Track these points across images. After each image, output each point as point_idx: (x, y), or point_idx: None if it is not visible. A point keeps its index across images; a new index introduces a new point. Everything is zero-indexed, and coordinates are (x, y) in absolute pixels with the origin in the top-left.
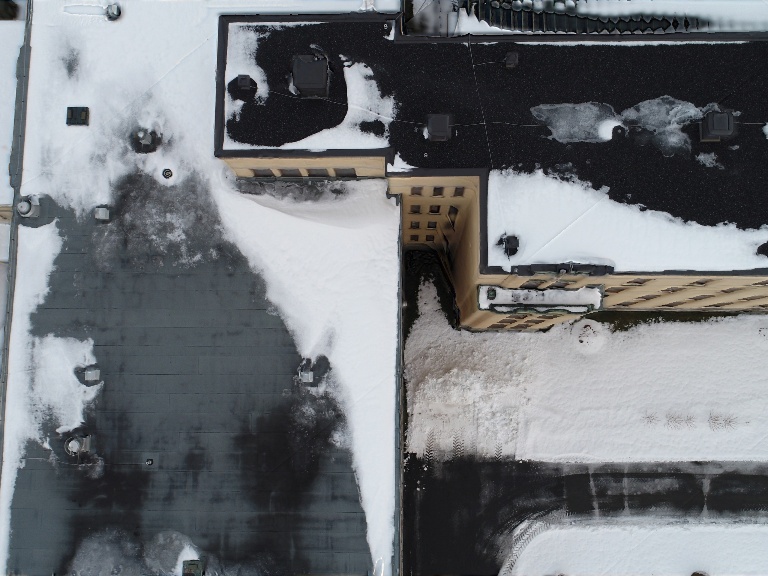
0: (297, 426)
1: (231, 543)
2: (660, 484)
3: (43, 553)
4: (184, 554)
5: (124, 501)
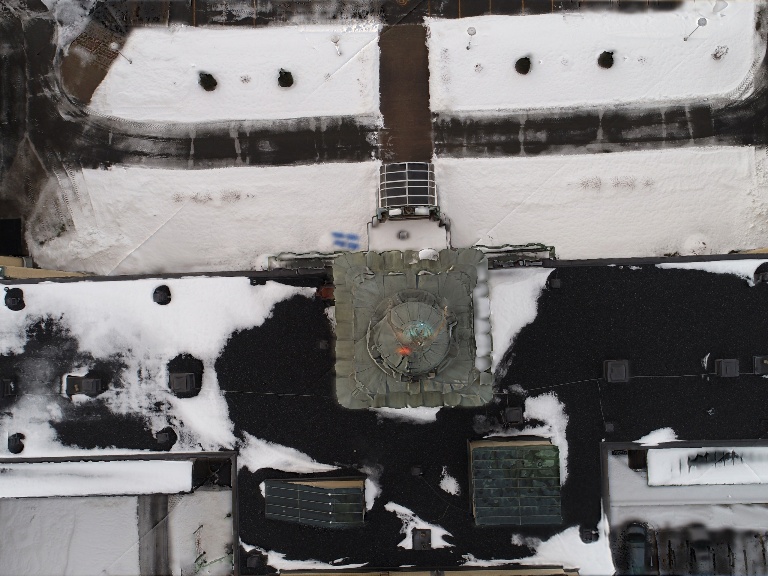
0: None
1: None
2: (637, 134)
3: None
4: None
5: None
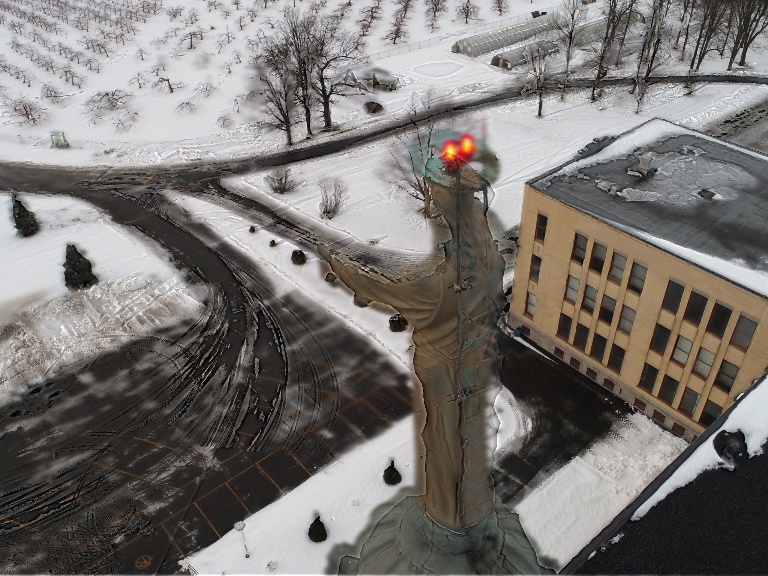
0: (762, 254)
1: (711, 209)
2: None
3: (761, 169)
4: (720, 196)
5: (767, 195)
